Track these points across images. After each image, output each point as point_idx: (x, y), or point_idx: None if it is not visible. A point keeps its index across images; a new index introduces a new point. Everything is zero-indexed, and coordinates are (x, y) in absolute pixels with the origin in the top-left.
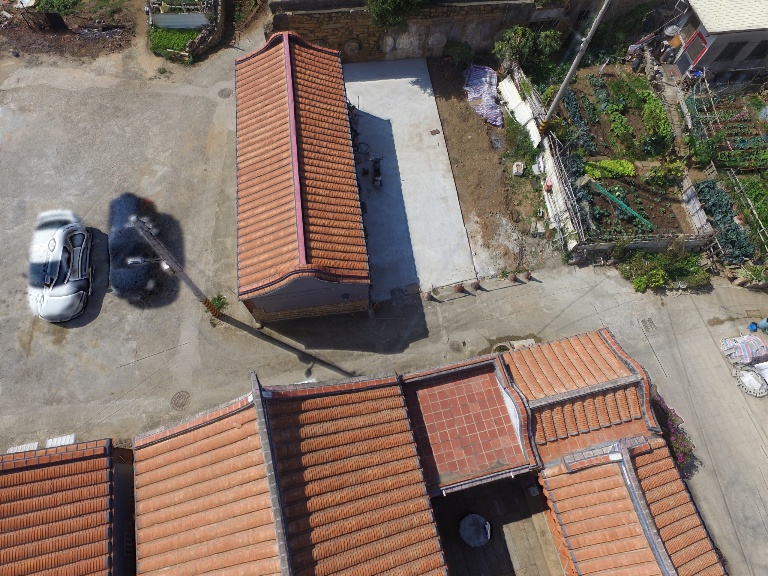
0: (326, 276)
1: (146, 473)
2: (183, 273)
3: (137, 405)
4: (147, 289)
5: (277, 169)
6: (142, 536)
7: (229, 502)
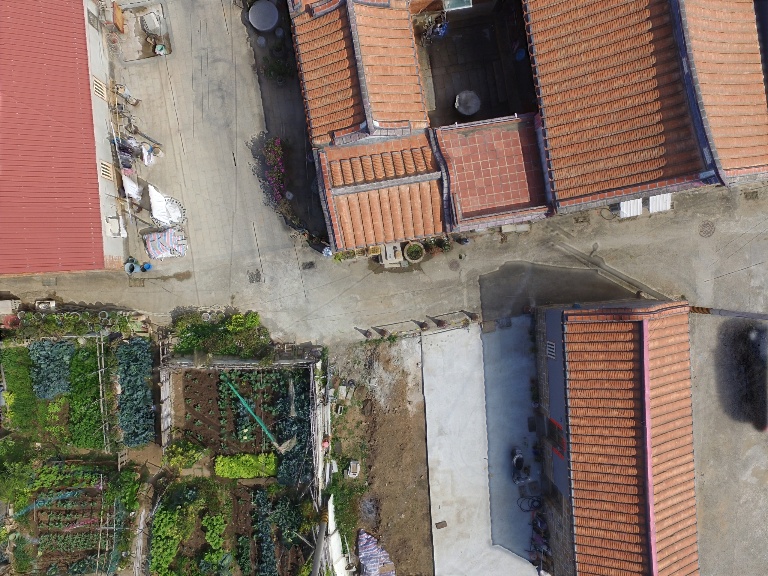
0: (617, 312)
1: (765, 144)
2: (759, 316)
3: (744, 228)
4: (748, 337)
5: (662, 444)
6: (763, 98)
7: (714, 106)
